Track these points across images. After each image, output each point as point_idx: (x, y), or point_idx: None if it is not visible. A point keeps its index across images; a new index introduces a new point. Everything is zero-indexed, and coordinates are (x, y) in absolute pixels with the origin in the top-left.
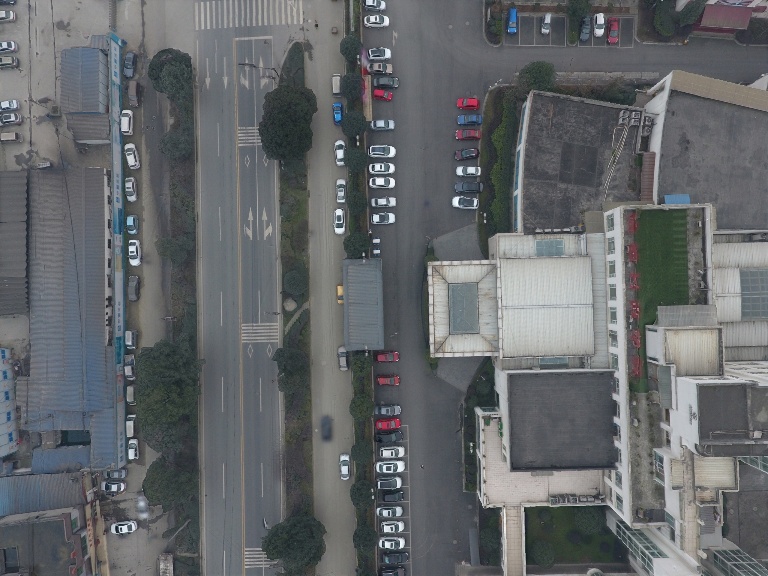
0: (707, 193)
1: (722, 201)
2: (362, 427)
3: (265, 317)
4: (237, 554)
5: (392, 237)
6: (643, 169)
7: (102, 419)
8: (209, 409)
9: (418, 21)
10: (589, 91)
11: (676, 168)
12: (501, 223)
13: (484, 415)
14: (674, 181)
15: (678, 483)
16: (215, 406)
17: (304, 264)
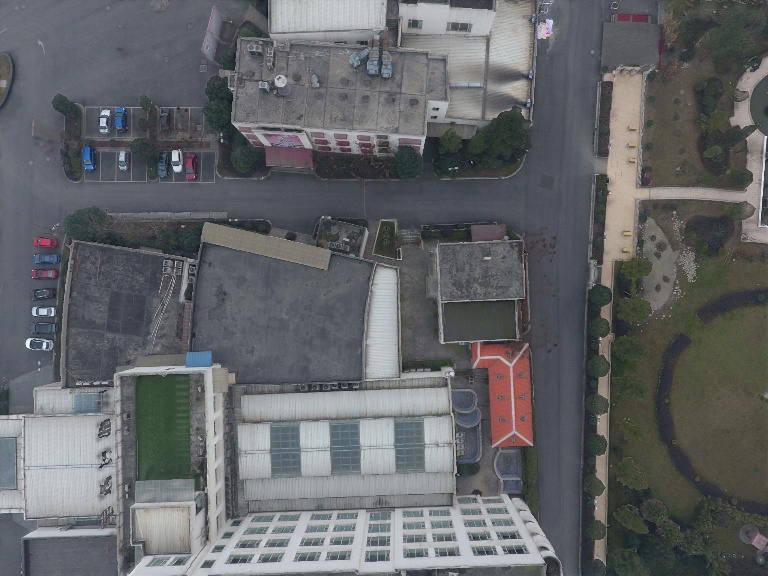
0: (243, 346)
1: (258, 354)
2: None
3: None
4: None
5: None
6: (184, 320)
7: None
8: None
9: None
10: None
11: (212, 320)
12: None
13: None
14: (210, 333)
15: None
16: None
17: None
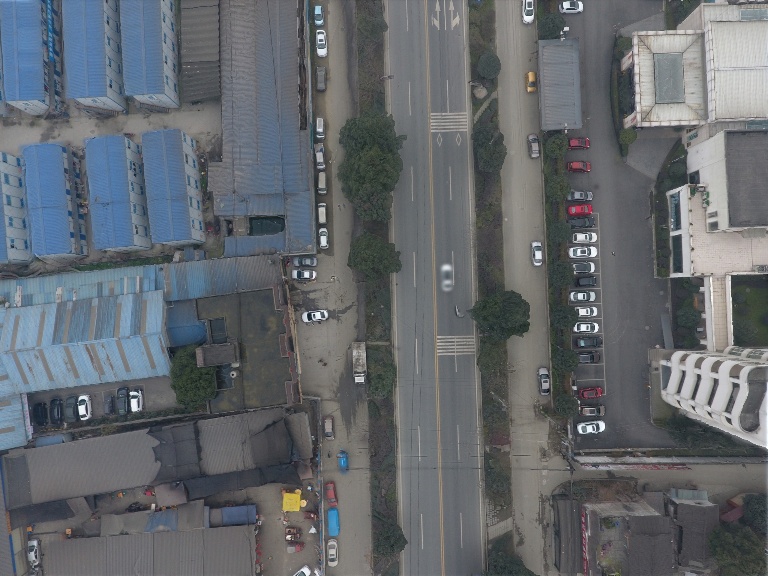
0: None
1: None
2: (555, 212)
3: (454, 107)
4: (429, 342)
5: (579, 27)
6: None
7: (298, 202)
8: (399, 198)
9: None
10: None
11: None
12: (693, 7)
13: (690, 184)
14: None
15: None
16: (405, 195)
17: (493, 53)
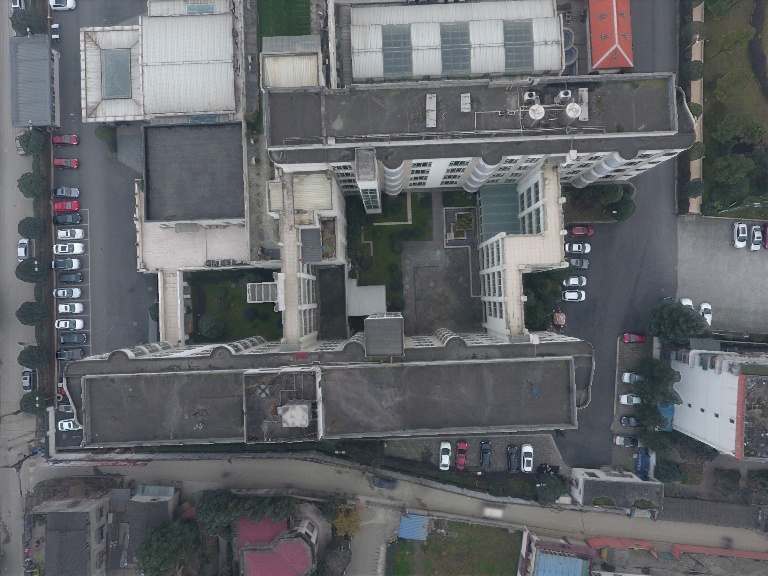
0: None
1: None
2: (38, 209)
3: None
4: None
5: (74, 24)
6: None
7: None
8: None
9: None
10: None
11: None
12: None
13: (138, 179)
14: None
15: (278, 207)
16: None
17: None
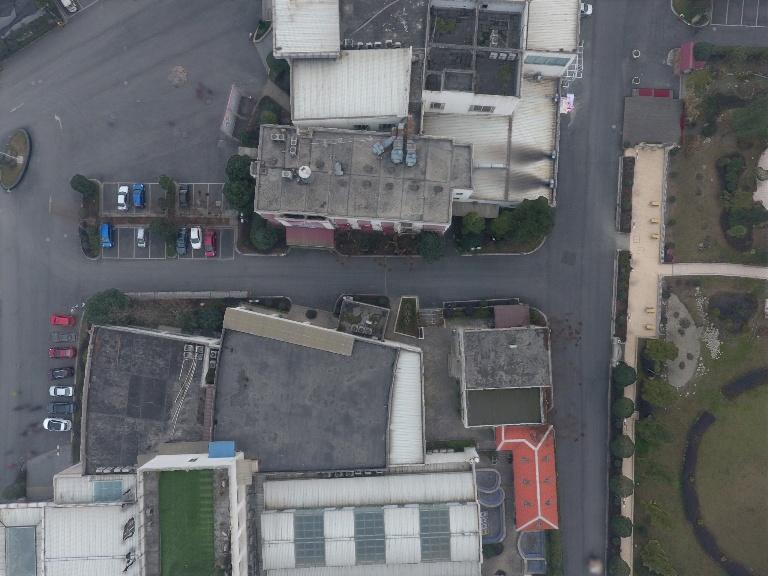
0: (266, 432)
1: (281, 441)
2: None
3: None
4: None
5: None
6: (205, 406)
7: None
8: None
9: (15, 234)
10: (185, 306)
11: (235, 407)
12: None
13: None
14: (232, 420)
15: None
16: None
17: None
